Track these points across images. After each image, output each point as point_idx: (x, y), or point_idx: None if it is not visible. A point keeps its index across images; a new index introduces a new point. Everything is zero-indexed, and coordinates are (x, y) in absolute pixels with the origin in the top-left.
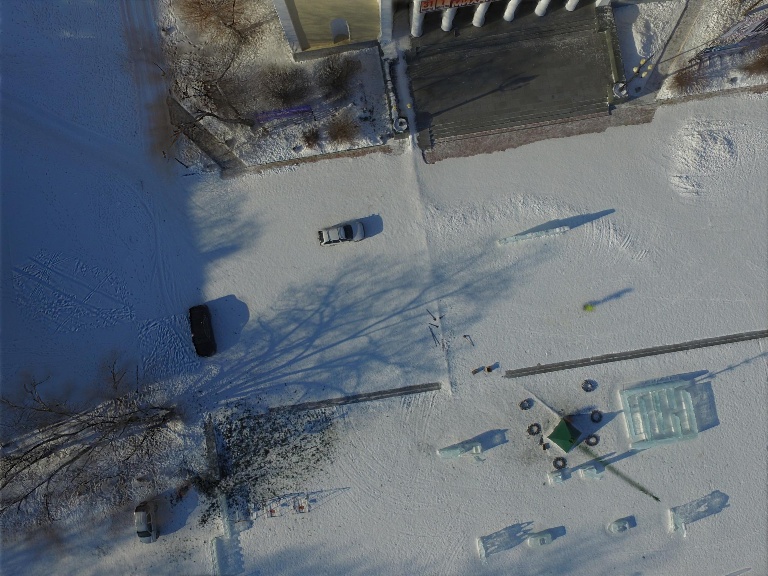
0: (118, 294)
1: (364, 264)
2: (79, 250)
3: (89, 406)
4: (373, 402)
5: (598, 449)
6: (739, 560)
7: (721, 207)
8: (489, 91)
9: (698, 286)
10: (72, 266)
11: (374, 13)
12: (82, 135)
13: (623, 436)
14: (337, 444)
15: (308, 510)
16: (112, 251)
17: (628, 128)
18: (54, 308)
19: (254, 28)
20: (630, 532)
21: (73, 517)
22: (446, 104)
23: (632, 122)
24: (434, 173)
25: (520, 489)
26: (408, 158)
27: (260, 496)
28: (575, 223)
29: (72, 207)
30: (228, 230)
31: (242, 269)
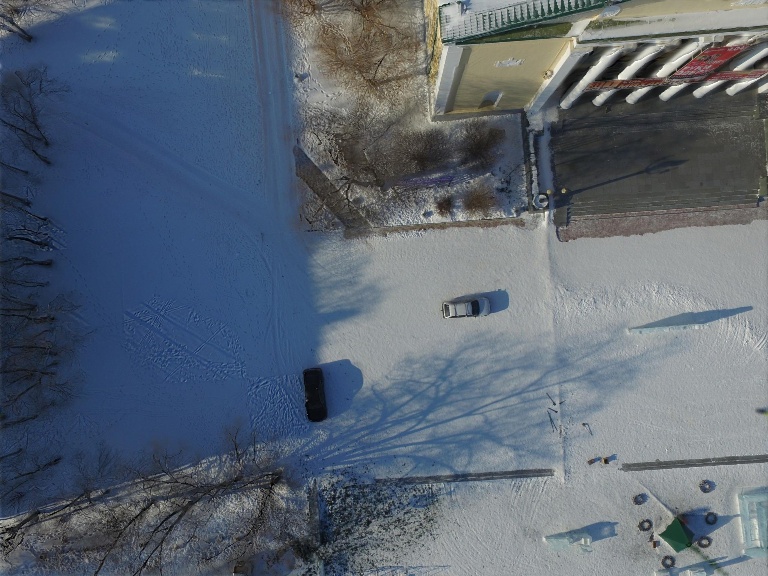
0: (230, 348)
1: (486, 340)
2: (193, 299)
3: (193, 460)
4: (482, 482)
5: (709, 552)
6: None
7: None
8: (635, 172)
9: None
10: (185, 315)
11: (534, 88)
12: (203, 179)
13: (737, 541)
14: (441, 521)
15: None
16: (227, 303)
17: None
18: (164, 357)
19: (390, 81)
20: None
21: (167, 568)
22: (588, 182)
23: None
24: (567, 252)
25: None
26: (541, 234)
27: (358, 566)
28: (710, 318)
29: (189, 254)
30: (348, 292)
31: (359, 334)
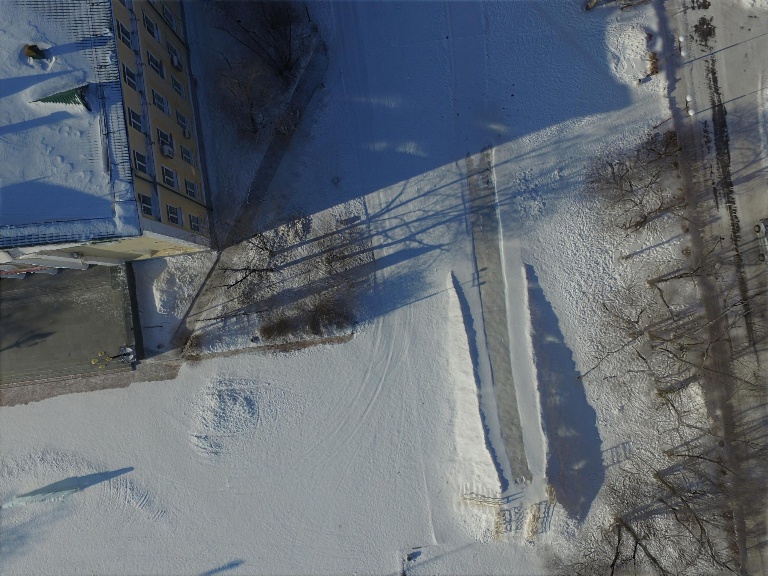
0: None
1: None
2: None
3: None
4: None
5: None
6: None
7: (240, 468)
8: (5, 347)
9: (212, 548)
10: None
11: None
12: None
13: None
14: None
15: None
16: None
17: (151, 384)
18: None
19: None
20: None
21: None
22: None
23: (156, 378)
24: None
25: None
26: None
27: None
28: (93, 481)
29: None
30: None
31: None
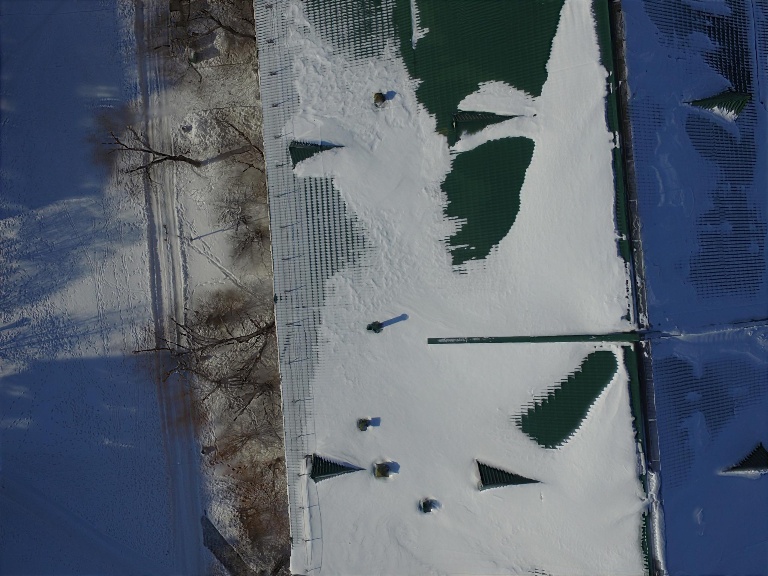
0: None
1: None
2: None
3: None
4: None
5: None
6: None
7: None
8: None
9: None
10: None
11: None
12: (114, 546)
13: None
14: None
15: None
16: None
17: None
18: None
19: None
20: None
21: None
22: None
23: None
24: None
25: None
26: None
27: None
28: None
29: None
30: None
31: None
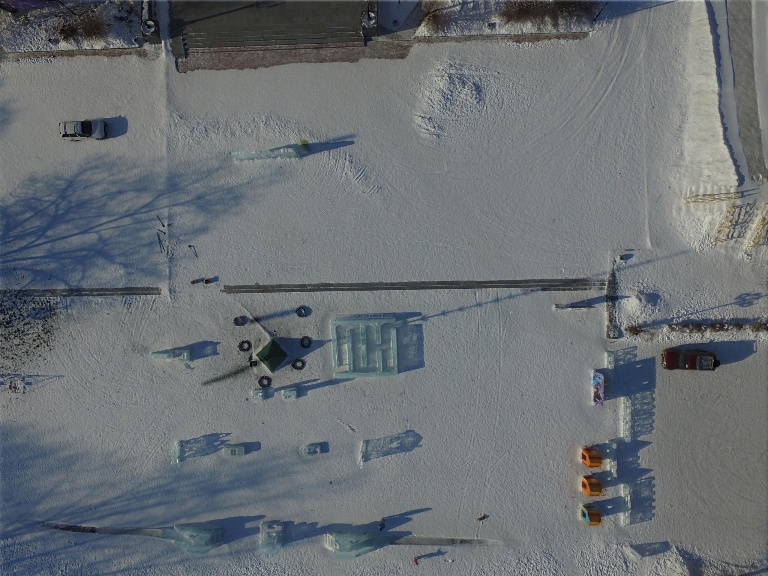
0: None
1: (104, 163)
2: None
3: None
4: (95, 298)
5: (303, 374)
6: (422, 499)
7: (460, 153)
8: (245, 5)
9: (423, 228)
10: None
11: None
12: None
13: (329, 365)
14: (57, 333)
15: (23, 391)
16: None
17: (381, 62)
18: None
19: None
20: (322, 457)
21: None
22: (201, 13)
23: (386, 56)
24: (184, 82)
25: (224, 401)
26: (161, 64)
27: None
28: (313, 150)
29: None
30: None
31: None
